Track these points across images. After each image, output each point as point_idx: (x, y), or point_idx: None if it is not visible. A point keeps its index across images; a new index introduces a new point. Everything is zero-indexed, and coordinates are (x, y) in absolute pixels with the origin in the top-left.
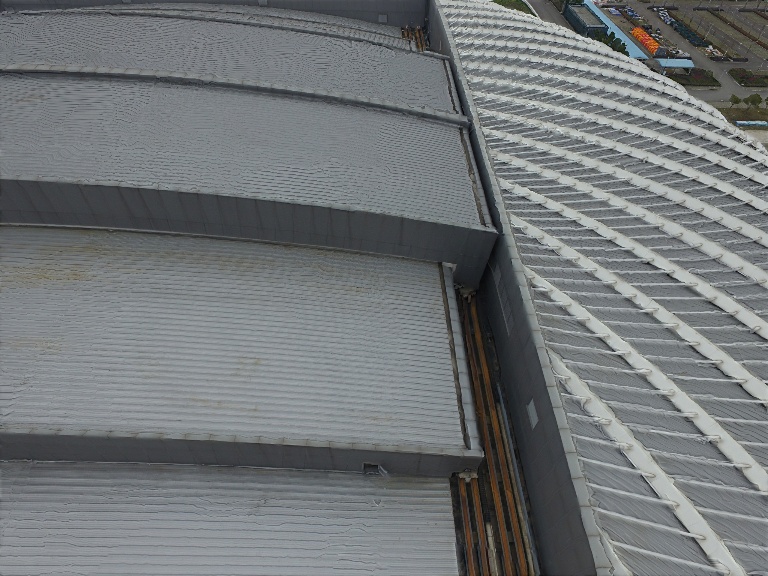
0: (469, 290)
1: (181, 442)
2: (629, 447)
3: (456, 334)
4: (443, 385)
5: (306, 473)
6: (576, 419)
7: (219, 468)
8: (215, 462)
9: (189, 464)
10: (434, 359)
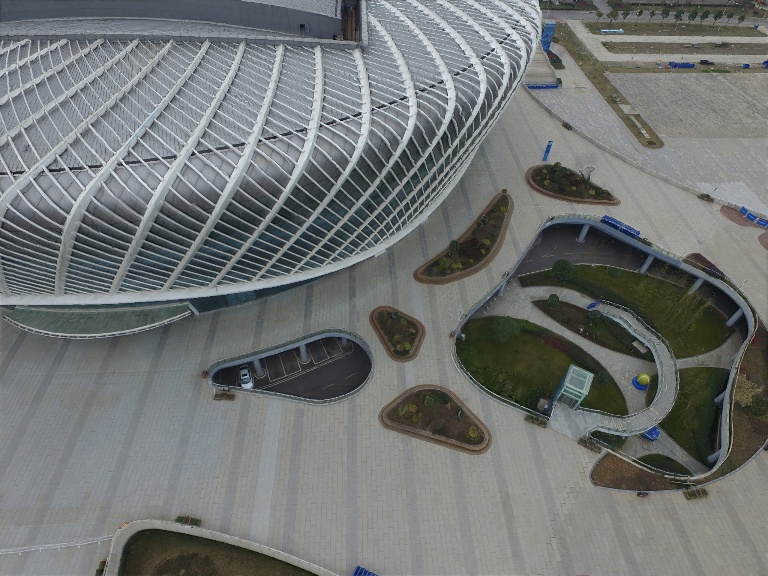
0: (351, 4)
1: (237, 3)
2: (386, 4)
3: (339, 2)
4: (330, 8)
5: (280, 34)
6: (371, 1)
7: (249, 29)
8: (248, 23)
9: (238, 27)
10: (328, 4)
